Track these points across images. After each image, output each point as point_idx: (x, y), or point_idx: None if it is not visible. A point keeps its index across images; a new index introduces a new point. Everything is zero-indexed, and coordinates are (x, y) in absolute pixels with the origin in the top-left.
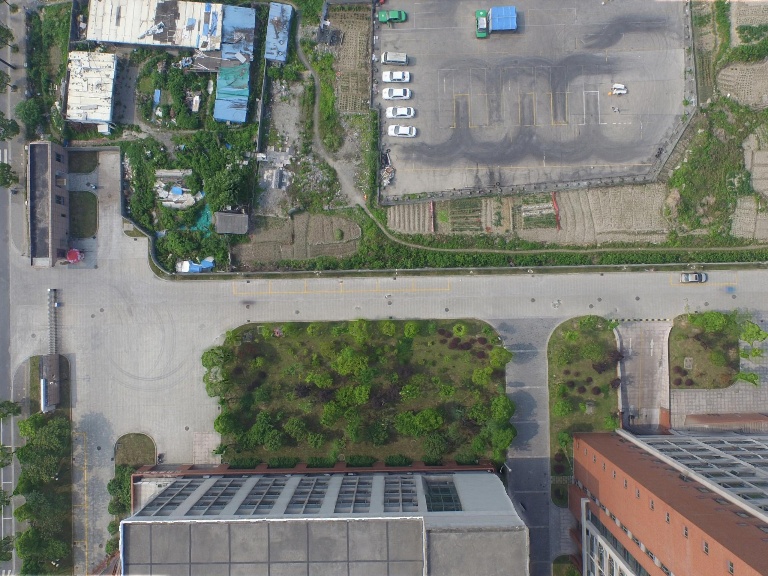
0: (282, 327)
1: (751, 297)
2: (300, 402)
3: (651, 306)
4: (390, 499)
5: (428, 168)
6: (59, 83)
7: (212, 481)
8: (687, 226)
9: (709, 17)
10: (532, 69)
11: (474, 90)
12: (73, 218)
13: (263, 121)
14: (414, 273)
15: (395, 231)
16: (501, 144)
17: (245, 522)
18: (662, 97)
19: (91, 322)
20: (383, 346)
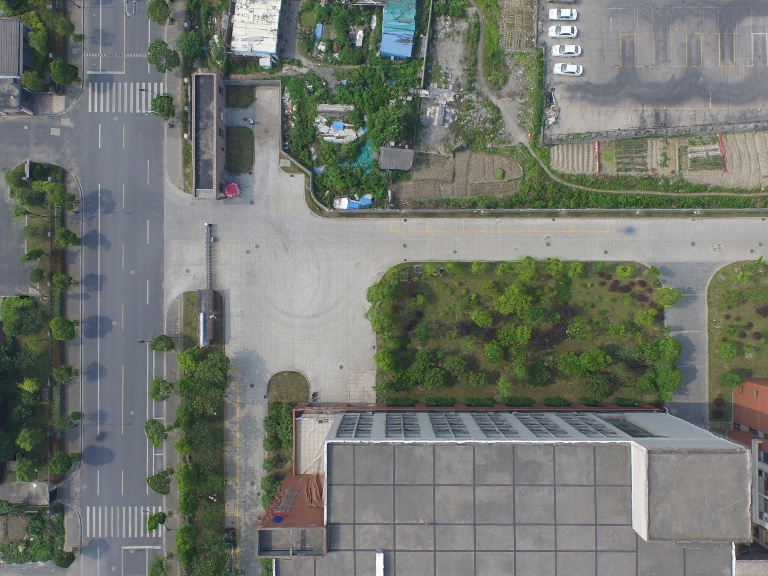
0: (440, 266)
1: None
2: (464, 340)
3: None
4: (581, 429)
5: (593, 107)
6: (219, 16)
7: (382, 415)
8: None
9: None
10: (700, 9)
11: (641, 30)
12: (230, 153)
13: (427, 57)
14: (573, 214)
15: (558, 171)
16: (667, 85)
17: (450, 444)
18: None
19: (246, 258)
20: (542, 287)
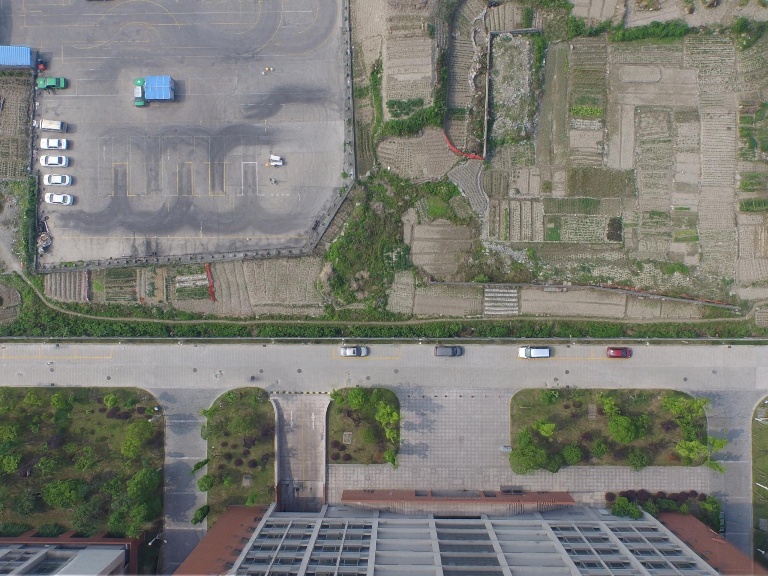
0: None
1: (413, 372)
2: None
3: (312, 379)
4: None
5: (85, 236)
6: None
7: None
8: (342, 300)
9: (368, 89)
10: (191, 138)
11: (133, 158)
12: None
13: None
14: (76, 340)
15: (52, 299)
16: (158, 213)
17: None
18: (321, 169)
19: None
20: (41, 413)
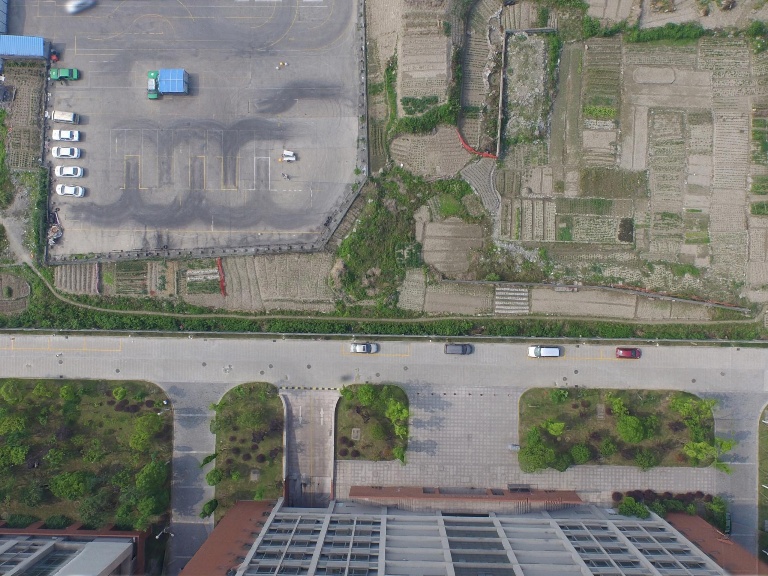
0: None
1: (423, 369)
2: None
3: (322, 375)
4: None
5: (96, 228)
6: None
7: None
8: (353, 297)
9: (382, 86)
10: (204, 132)
11: (145, 151)
12: None
13: None
14: (86, 333)
15: (62, 291)
16: (170, 207)
17: None
18: (334, 165)
19: None
20: (50, 405)
